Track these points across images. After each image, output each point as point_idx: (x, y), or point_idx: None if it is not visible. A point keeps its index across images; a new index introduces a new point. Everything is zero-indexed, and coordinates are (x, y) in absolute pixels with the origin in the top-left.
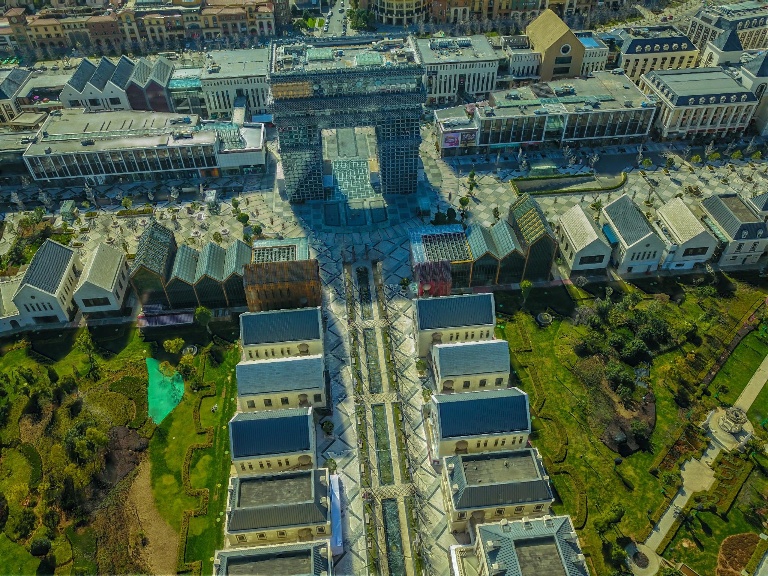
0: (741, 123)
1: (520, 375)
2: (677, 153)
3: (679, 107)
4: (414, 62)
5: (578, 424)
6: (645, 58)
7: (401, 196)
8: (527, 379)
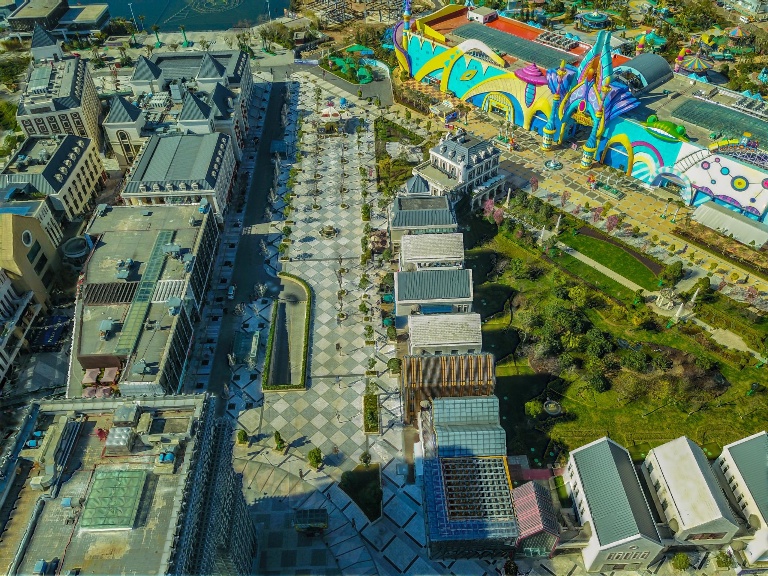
0: (233, 163)
1: (647, 451)
2: (250, 224)
3: (216, 188)
4: (163, 411)
5: (701, 411)
6: (72, 182)
7: (260, 559)
8: (652, 445)
